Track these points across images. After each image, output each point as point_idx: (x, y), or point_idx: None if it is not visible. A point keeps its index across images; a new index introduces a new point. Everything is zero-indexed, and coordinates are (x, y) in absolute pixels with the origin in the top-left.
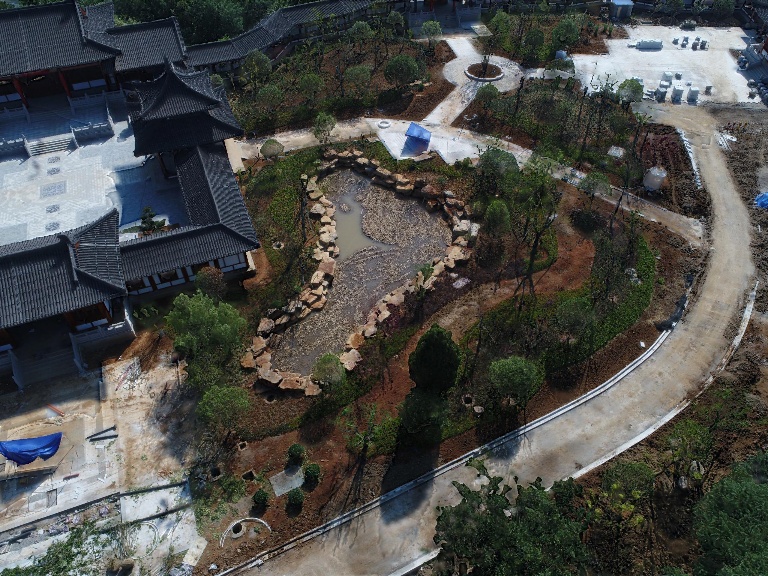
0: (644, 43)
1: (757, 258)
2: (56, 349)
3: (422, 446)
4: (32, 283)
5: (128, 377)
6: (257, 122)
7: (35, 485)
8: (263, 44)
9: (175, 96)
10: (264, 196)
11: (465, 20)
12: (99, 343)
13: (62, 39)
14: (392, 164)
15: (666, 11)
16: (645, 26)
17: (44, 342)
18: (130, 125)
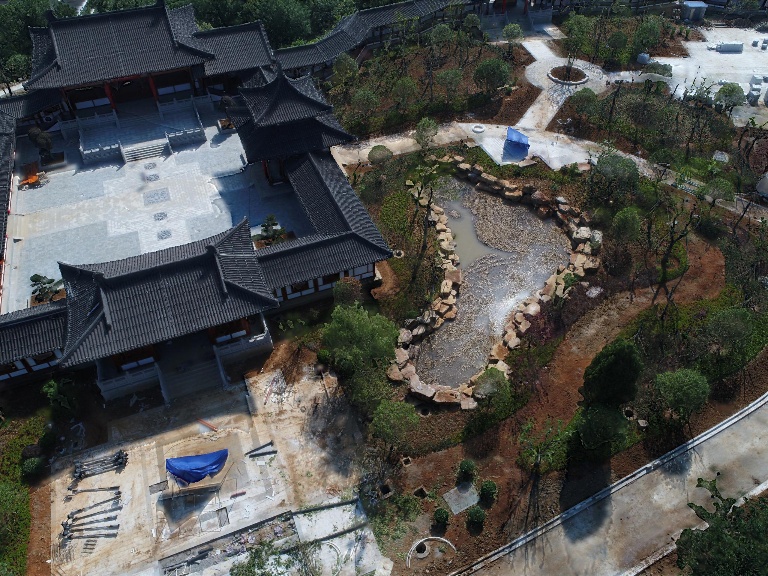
0: (725, 45)
1: None
2: (198, 362)
3: (593, 461)
4: (182, 295)
5: (274, 390)
6: (350, 127)
7: (203, 503)
8: (346, 48)
9: (286, 102)
10: (374, 203)
11: (536, 22)
12: (239, 355)
13: (153, 43)
14: (496, 170)
15: (740, 13)
16: (720, 28)
17: (185, 355)
18: (221, 130)
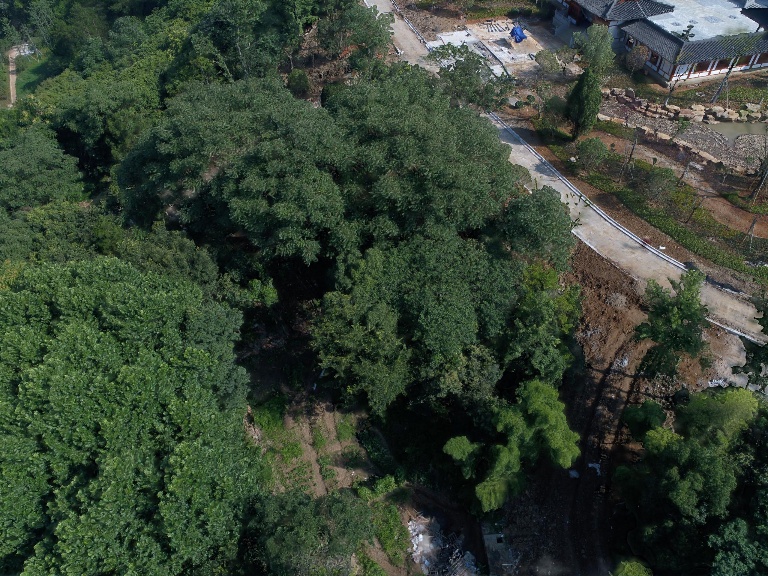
0: None
1: None
2: None
3: (542, 139)
4: None
5: None
6: None
7: (505, 46)
8: None
9: None
10: (755, 85)
11: None
12: None
13: None
14: None
15: None
16: None
17: None
18: None
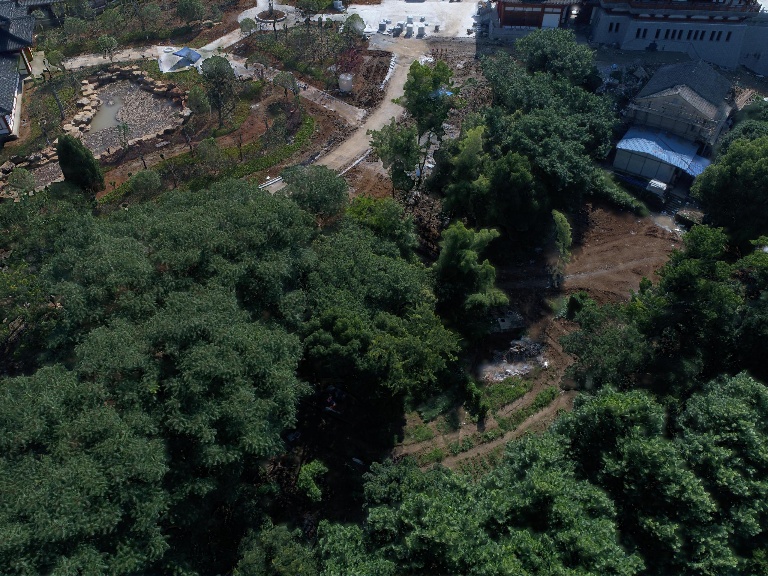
0: None
1: None
2: None
3: None
4: None
5: None
6: (67, 47)
7: None
8: None
9: None
10: (48, 93)
11: None
12: None
13: None
14: (157, 74)
15: None
16: None
17: None
18: None
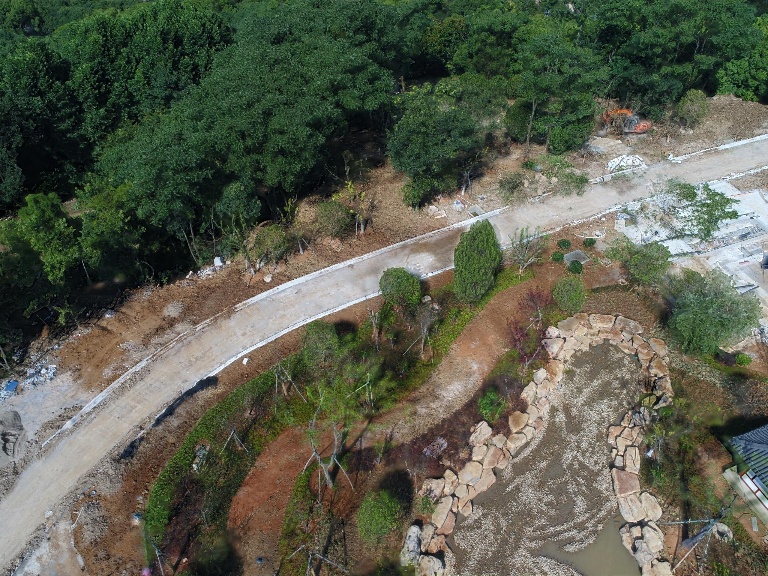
0: None
1: (5, 487)
2: None
3: None
4: None
5: None
6: None
7: (767, 258)
8: None
9: None
10: None
11: None
12: None
13: None
14: None
15: None
16: None
17: None
18: None
